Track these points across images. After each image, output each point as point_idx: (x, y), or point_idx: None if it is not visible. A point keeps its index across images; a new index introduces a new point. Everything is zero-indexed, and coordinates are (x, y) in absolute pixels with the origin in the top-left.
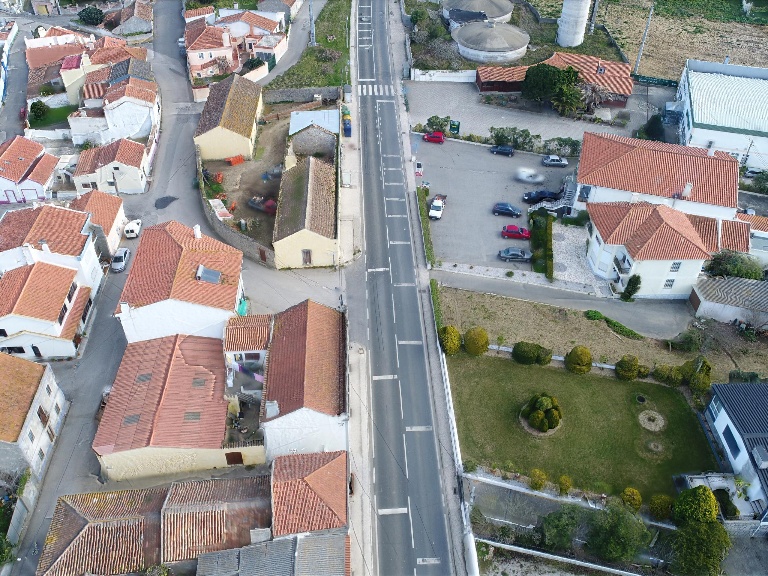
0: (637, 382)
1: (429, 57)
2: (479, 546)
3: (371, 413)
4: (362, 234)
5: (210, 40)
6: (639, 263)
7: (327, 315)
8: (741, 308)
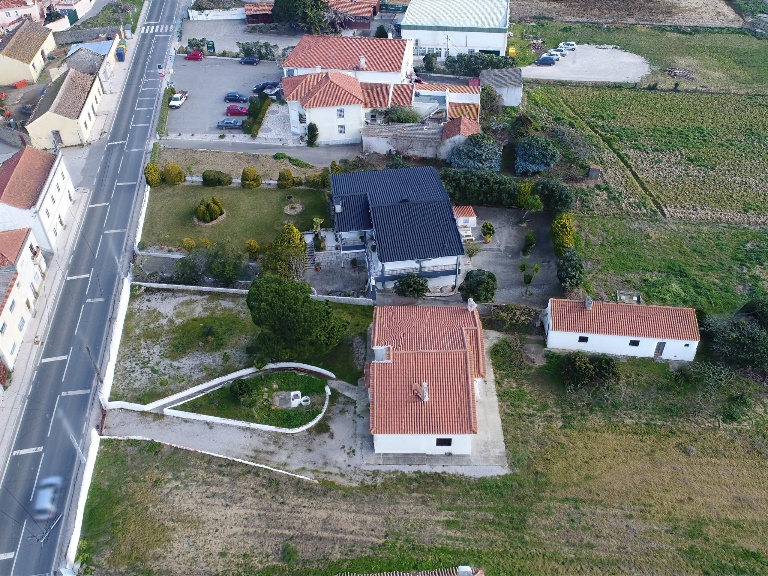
0: (292, 189)
1: (206, 1)
2: (134, 287)
3: (81, 226)
4: (111, 122)
5: (15, 0)
6: (310, 112)
7: (43, 156)
8: (390, 139)
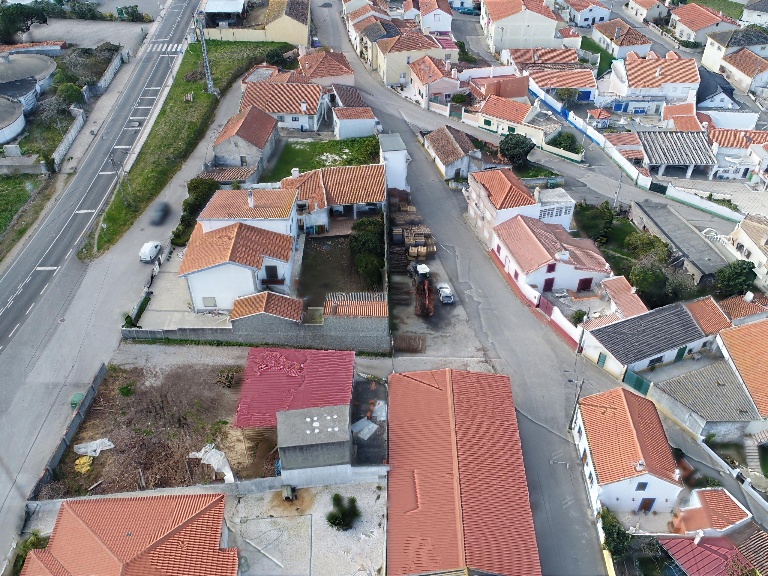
0: None
1: None
2: None
3: None
4: None
5: None
6: None
7: None
8: None
